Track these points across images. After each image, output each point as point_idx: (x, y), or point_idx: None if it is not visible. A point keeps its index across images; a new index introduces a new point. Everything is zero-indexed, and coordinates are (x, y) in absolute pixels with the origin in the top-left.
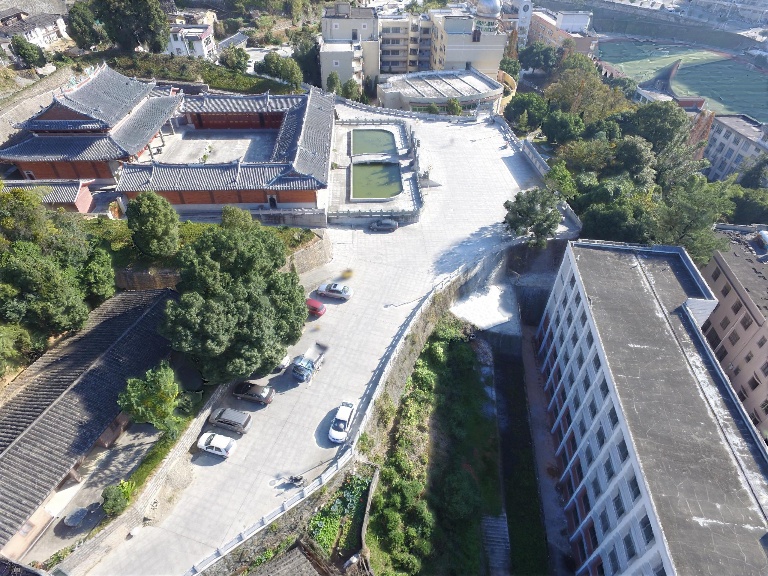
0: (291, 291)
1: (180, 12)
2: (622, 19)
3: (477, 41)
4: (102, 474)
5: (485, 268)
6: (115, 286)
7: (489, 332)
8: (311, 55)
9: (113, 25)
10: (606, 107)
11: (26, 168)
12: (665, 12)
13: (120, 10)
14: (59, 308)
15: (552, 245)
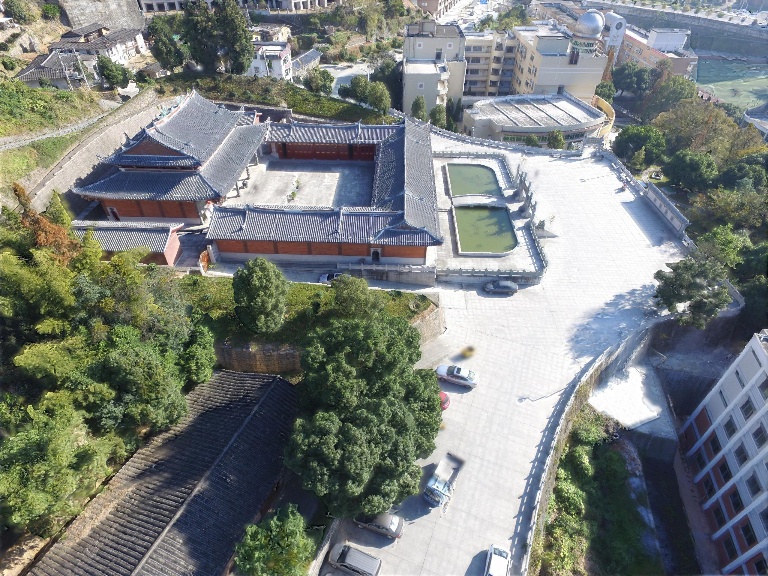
0: (431, 397)
1: (255, 27)
2: (707, 35)
3: (574, 64)
4: None
5: (627, 349)
6: None
7: (636, 432)
8: (392, 75)
9: (198, 45)
10: (737, 145)
11: (110, 205)
12: (758, 28)
13: (207, 30)
14: (159, 409)
15: (706, 322)
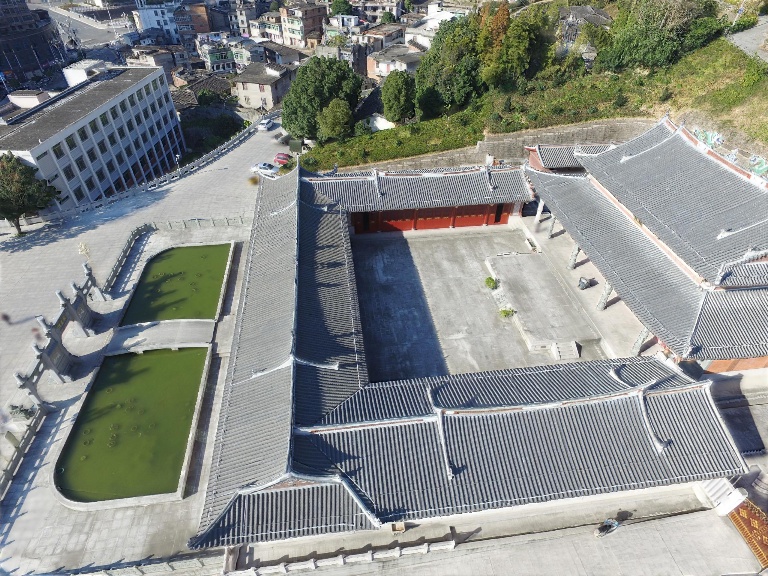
0: None
1: None
2: None
3: None
4: None
5: None
6: None
7: None
8: None
9: None
10: None
11: None
12: None
13: None
14: None
15: None
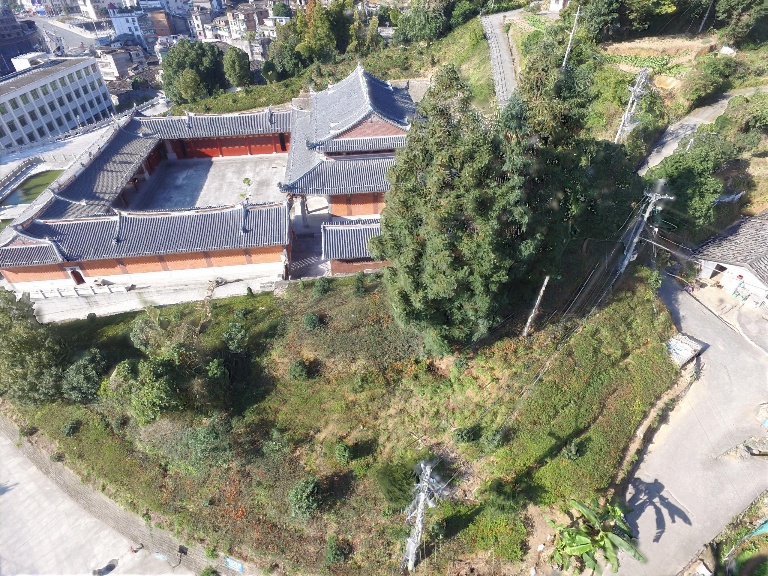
0: None
1: None
2: None
3: None
4: None
5: None
6: None
7: None
8: None
9: None
10: None
11: None
12: None
13: None
14: None
15: None
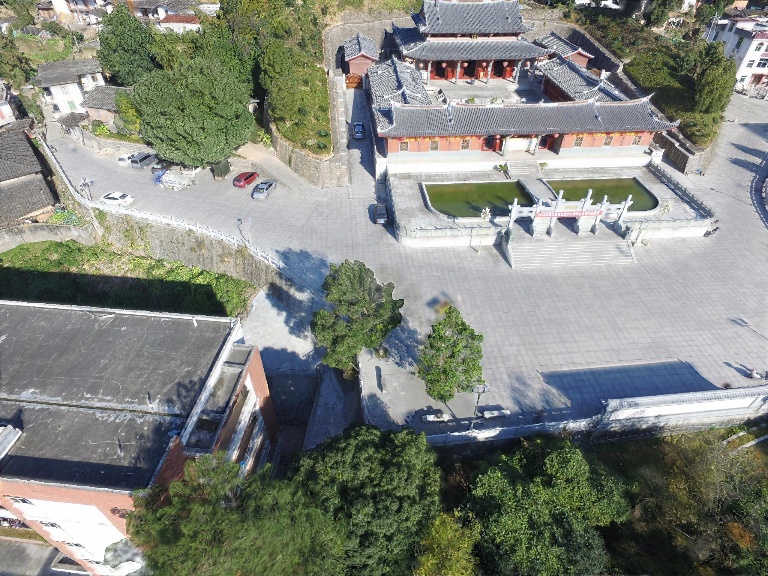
0: None
1: None
2: None
3: None
4: (127, 129)
5: None
6: (255, 92)
7: None
8: None
9: None
10: None
11: None
12: None
13: None
14: None
15: None
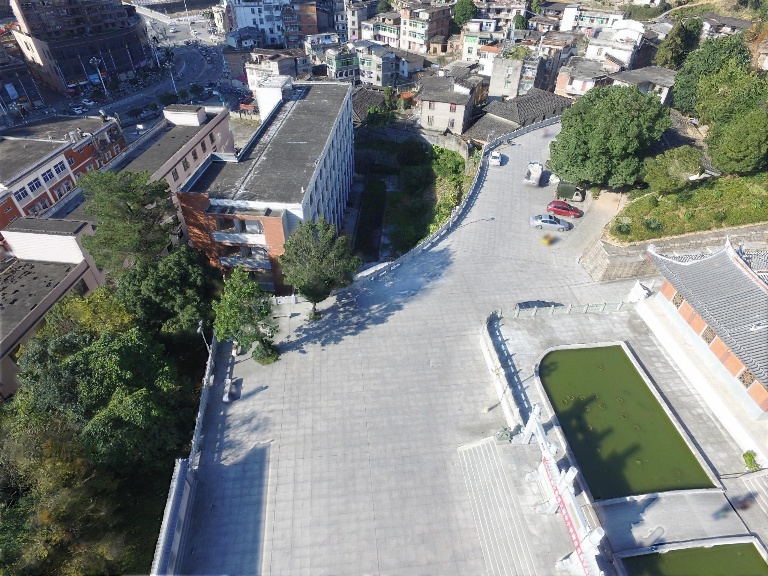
0: None
1: None
2: None
3: None
4: None
5: None
6: None
7: None
8: None
9: None
10: None
11: None
12: None
13: None
14: None
15: None
